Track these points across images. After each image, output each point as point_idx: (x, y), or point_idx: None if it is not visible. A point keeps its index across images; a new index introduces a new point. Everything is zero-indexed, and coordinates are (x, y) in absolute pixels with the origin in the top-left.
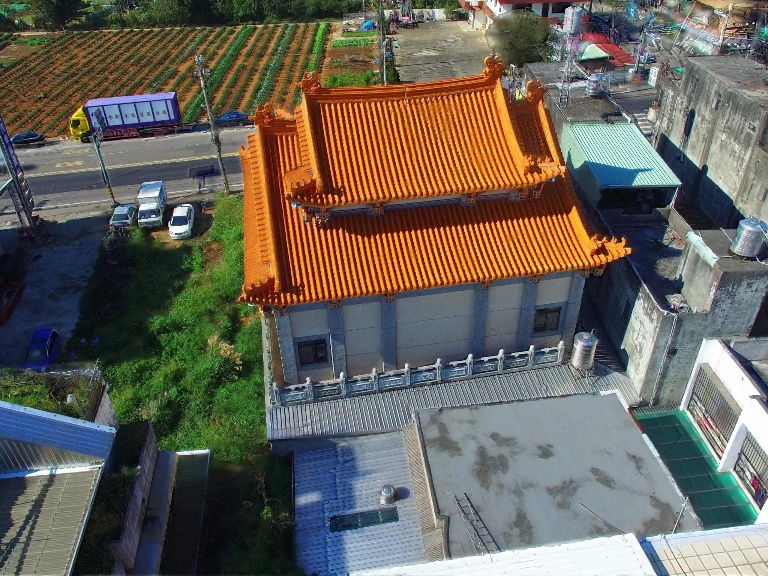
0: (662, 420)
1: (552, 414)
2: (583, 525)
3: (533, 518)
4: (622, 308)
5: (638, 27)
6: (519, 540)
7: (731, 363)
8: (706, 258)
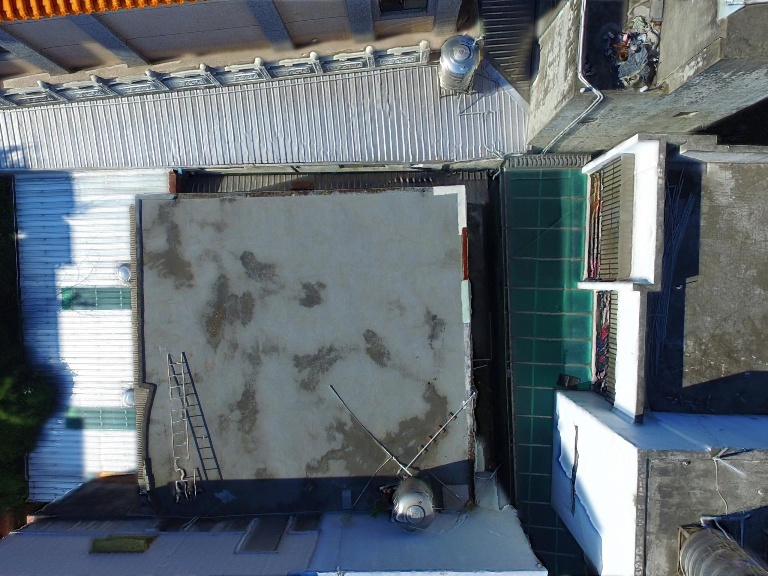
0: (546, 186)
1: (343, 225)
2: (323, 416)
3: (262, 400)
4: None
5: None
6: (236, 428)
7: (652, 199)
8: None
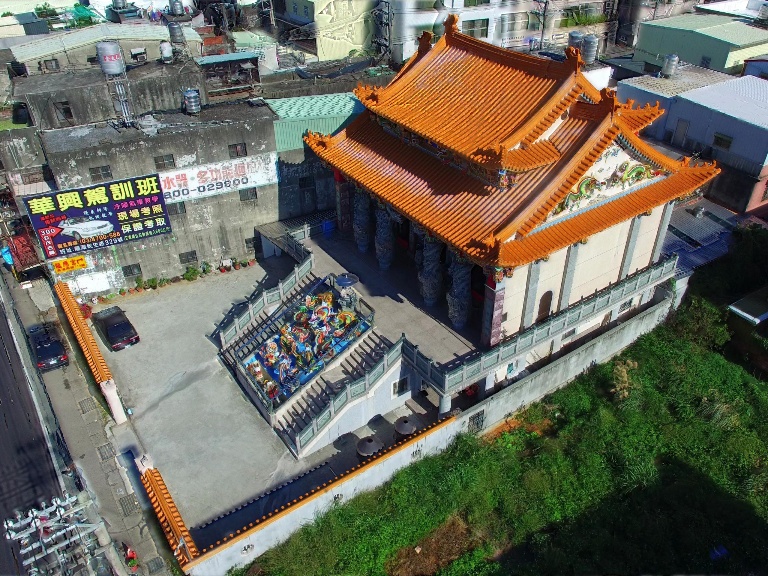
0: None
1: None
2: None
3: None
4: None
5: None
6: None
7: None
8: None
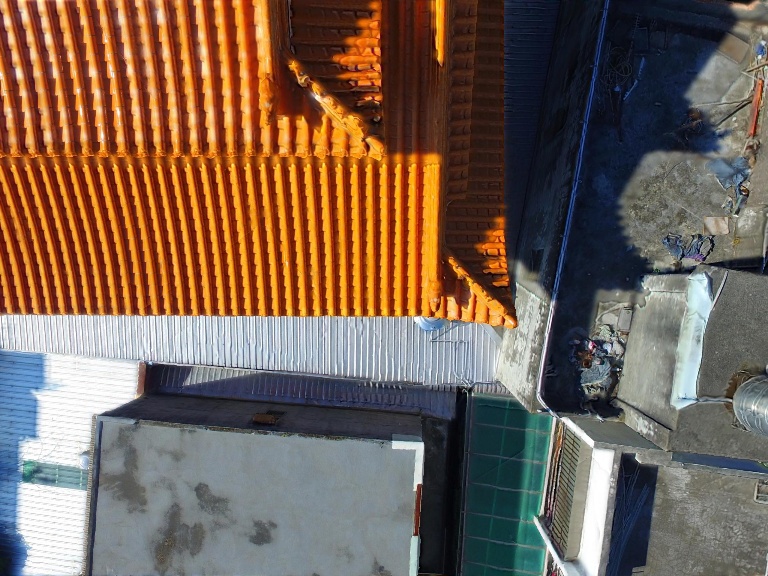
0: (512, 416)
1: (300, 468)
2: None
3: None
4: (537, 247)
5: None
6: None
7: (602, 504)
8: (677, 369)
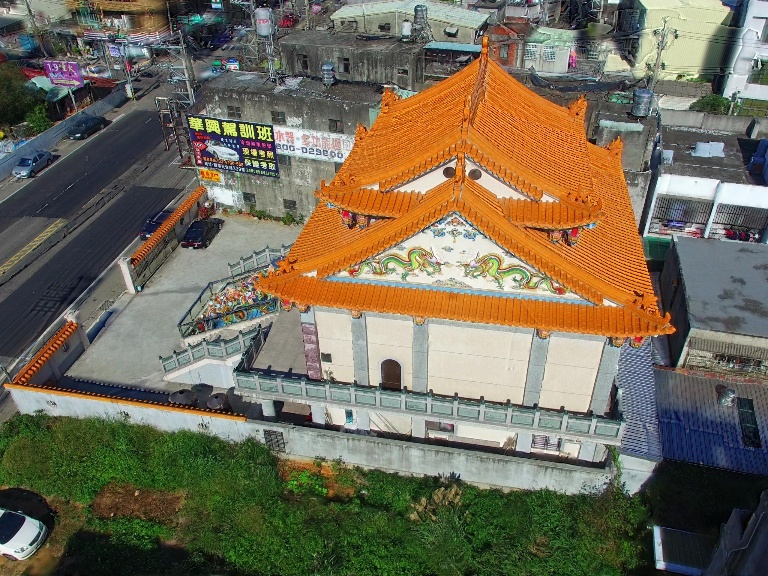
0: (653, 247)
1: (698, 266)
2: None
3: None
4: None
5: (199, 30)
6: None
7: (684, 179)
8: (631, 129)
